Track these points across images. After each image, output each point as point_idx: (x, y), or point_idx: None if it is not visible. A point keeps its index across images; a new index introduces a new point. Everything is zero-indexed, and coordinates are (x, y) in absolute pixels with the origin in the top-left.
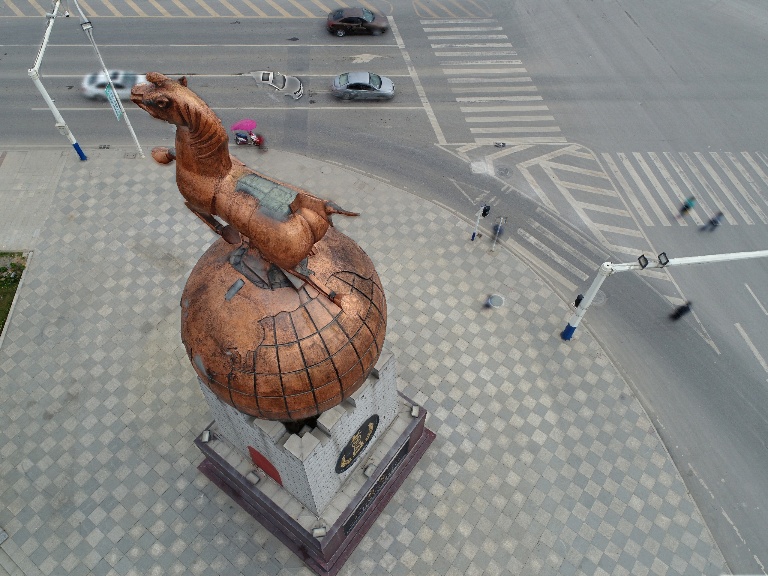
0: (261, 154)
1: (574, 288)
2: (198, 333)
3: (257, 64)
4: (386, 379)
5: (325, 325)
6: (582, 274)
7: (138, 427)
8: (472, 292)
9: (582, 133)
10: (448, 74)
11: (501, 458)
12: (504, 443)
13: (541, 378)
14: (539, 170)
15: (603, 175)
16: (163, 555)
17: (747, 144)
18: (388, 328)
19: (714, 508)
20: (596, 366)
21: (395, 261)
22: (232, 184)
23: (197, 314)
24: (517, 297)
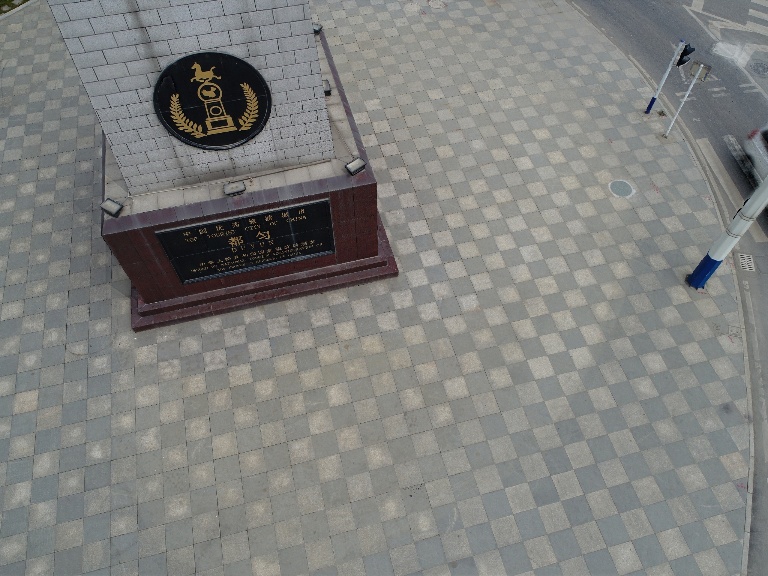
0: None
1: (761, 239)
2: None
3: None
4: None
5: None
6: None
7: None
8: (594, 162)
9: None
10: None
11: (462, 354)
12: (482, 340)
13: (609, 305)
14: None
15: None
16: (27, 196)
17: None
18: (448, 140)
19: None
20: (714, 344)
21: (520, 85)
22: None
23: None
24: (657, 200)
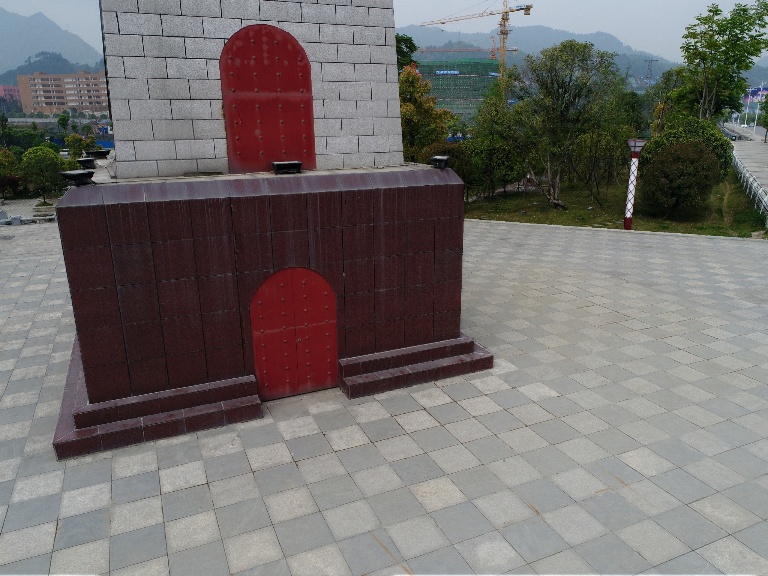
0: None
1: None
2: None
3: None
4: None
5: None
6: None
7: None
8: None
9: None
10: None
11: None
12: None
13: None
14: None
15: None
16: None
17: None
18: (482, 494)
19: None
20: None
21: None
22: None
23: None
24: None
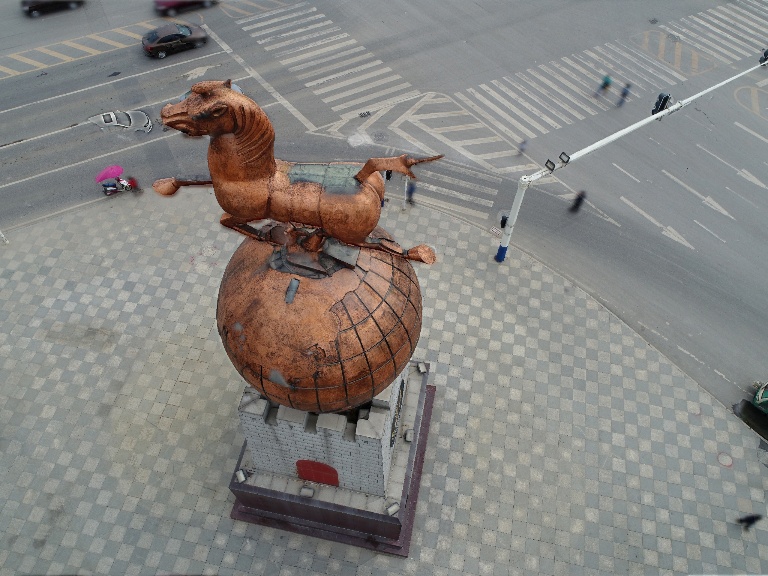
0: (138, 197)
1: (486, 216)
2: (268, 348)
3: (88, 110)
4: None
5: (386, 292)
6: (487, 202)
7: (147, 508)
8: None
9: (430, 82)
10: (287, 64)
11: (497, 382)
12: (494, 368)
13: (497, 301)
14: (409, 125)
15: (464, 112)
16: None
17: (563, 50)
18: None
19: (671, 347)
20: (535, 274)
21: None
22: (284, 179)
23: (259, 330)
24: (444, 241)
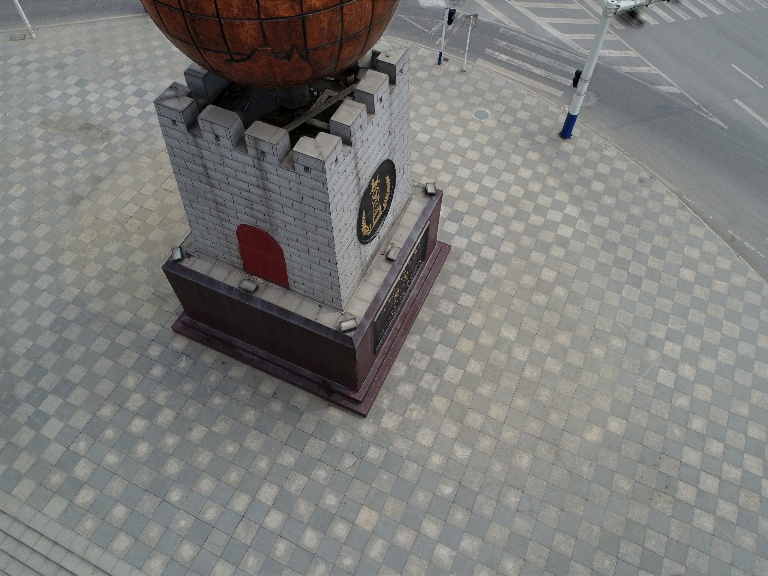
0: None
1: (560, 93)
2: None
3: None
4: (401, 97)
5: None
6: (565, 80)
7: (85, 301)
8: (452, 110)
9: None
10: None
11: (529, 257)
12: (528, 243)
13: (550, 177)
14: None
15: None
16: (147, 430)
17: None
18: None
19: (767, 266)
20: (605, 157)
21: None
22: None
23: None
24: (502, 108)
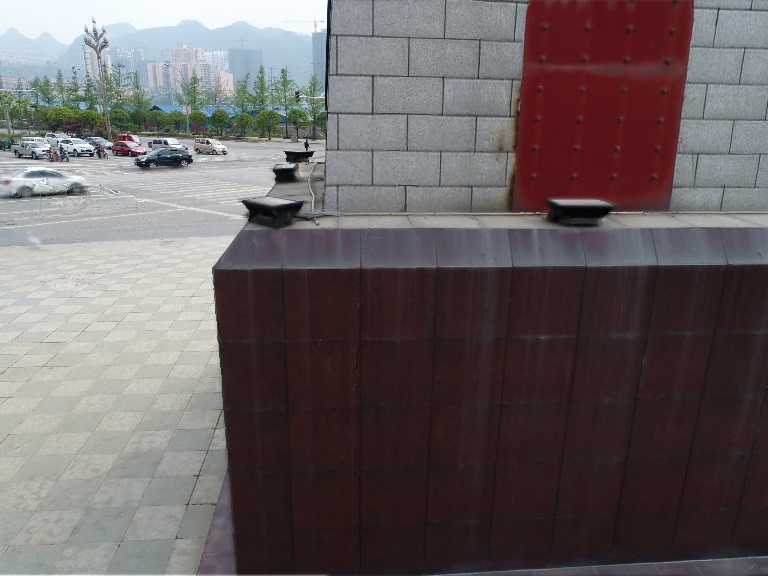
0: None
1: None
2: None
3: None
4: None
5: None
6: None
7: None
8: None
9: None
10: (191, 196)
11: None
12: None
13: None
14: None
15: None
16: None
17: None
18: None
19: None
20: None
21: None
22: None
23: None
24: None
